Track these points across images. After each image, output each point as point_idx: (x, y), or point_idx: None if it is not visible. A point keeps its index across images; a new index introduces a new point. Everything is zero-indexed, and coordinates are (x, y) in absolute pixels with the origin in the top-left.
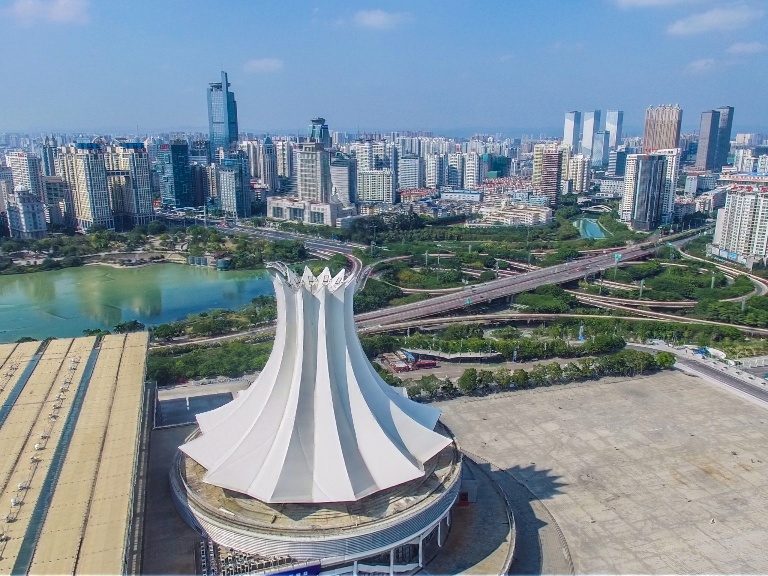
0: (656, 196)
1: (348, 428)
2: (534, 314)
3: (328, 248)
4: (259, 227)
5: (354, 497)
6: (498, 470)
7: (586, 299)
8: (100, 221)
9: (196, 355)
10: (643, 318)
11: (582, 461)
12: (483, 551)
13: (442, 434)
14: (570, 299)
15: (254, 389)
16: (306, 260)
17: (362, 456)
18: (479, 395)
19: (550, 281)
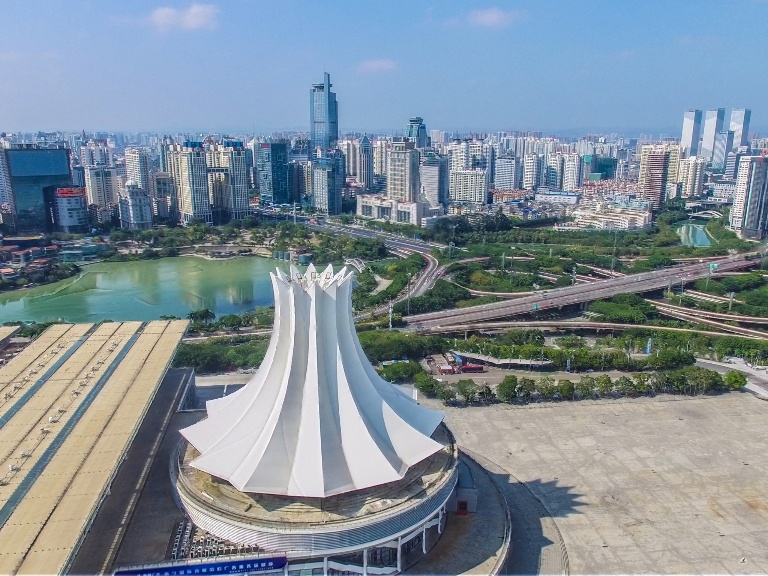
0: None
1: (334, 425)
2: (605, 323)
3: (409, 247)
4: (347, 224)
5: (323, 494)
6: (516, 482)
7: (668, 310)
8: None
9: (252, 345)
10: (728, 334)
11: (611, 481)
12: (468, 563)
13: (443, 439)
14: (649, 309)
15: (252, 380)
16: (385, 258)
17: (344, 454)
18: (518, 403)
19: (630, 289)
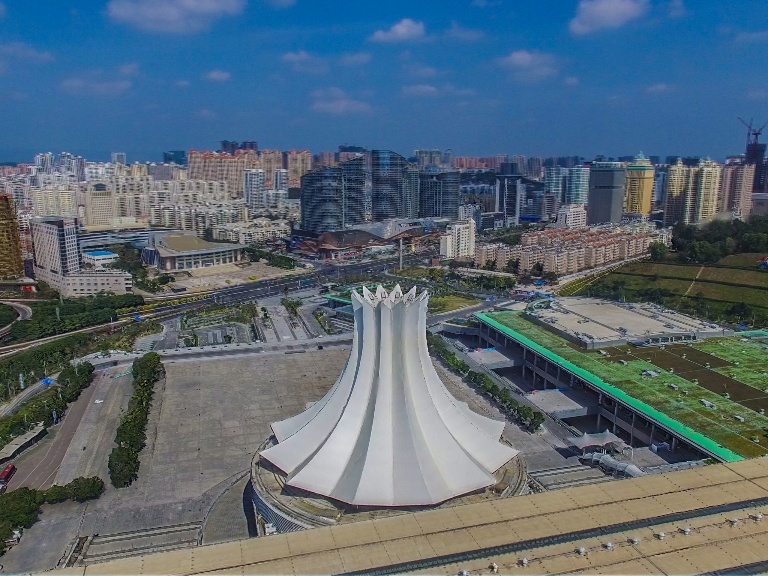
0: None
1: None
2: None
3: None
4: None
5: None
6: None
7: None
8: None
9: None
10: None
11: None
12: None
13: None
14: None
15: (409, 416)
16: None
17: None
18: (141, 447)
19: None
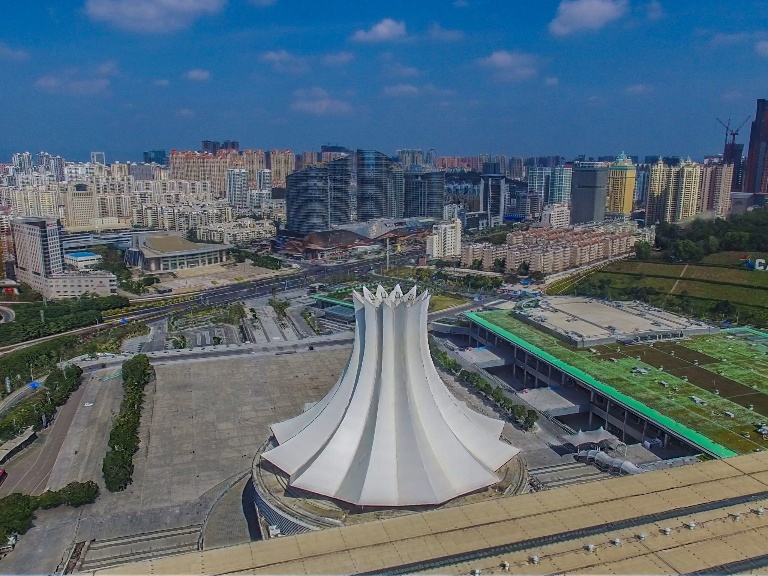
0: None
1: None
2: None
3: None
4: None
5: None
6: None
7: None
8: None
9: None
10: None
11: None
12: None
13: None
14: None
15: (412, 416)
16: None
17: None
18: (135, 450)
19: None
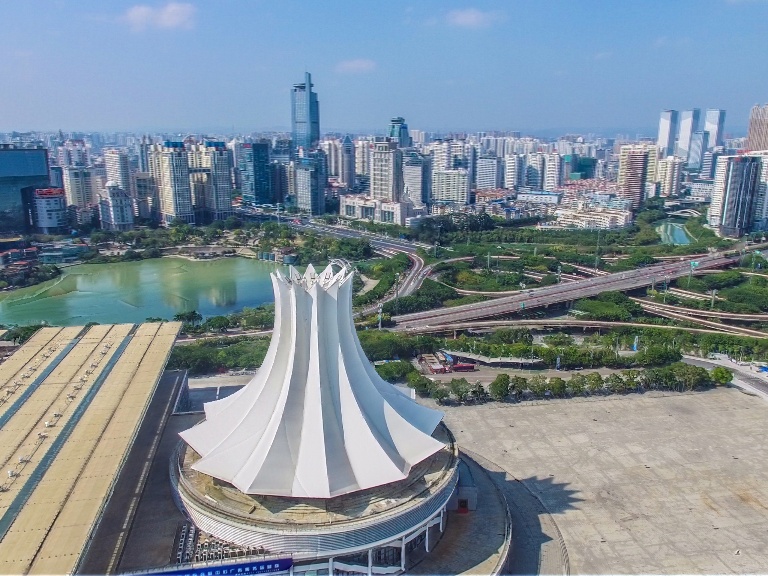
0: (748, 201)
1: (336, 425)
2: (591, 321)
3: (393, 247)
4: (330, 225)
5: (329, 494)
6: (513, 479)
7: (652, 308)
8: (182, 216)
9: (241, 347)
10: (711, 330)
11: (605, 477)
12: (471, 561)
13: (443, 438)
14: (634, 307)
15: (252, 381)
16: (371, 258)
17: (347, 454)
18: (511, 401)
19: (615, 287)
